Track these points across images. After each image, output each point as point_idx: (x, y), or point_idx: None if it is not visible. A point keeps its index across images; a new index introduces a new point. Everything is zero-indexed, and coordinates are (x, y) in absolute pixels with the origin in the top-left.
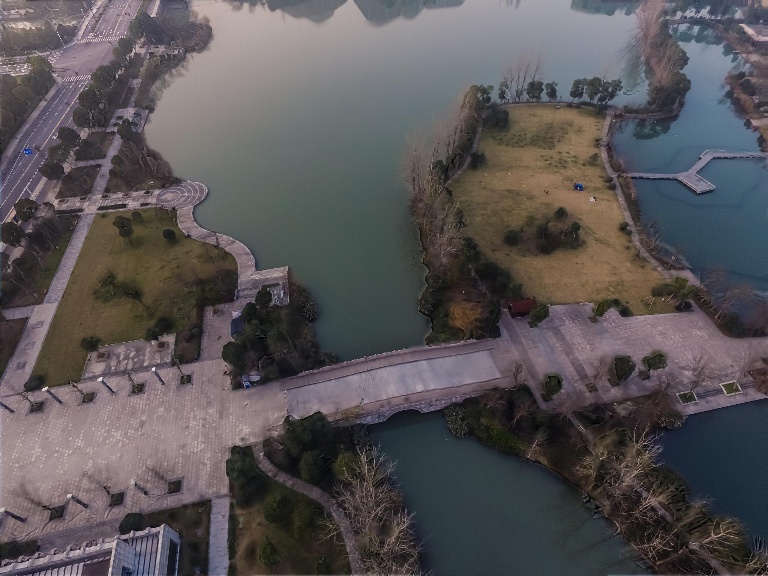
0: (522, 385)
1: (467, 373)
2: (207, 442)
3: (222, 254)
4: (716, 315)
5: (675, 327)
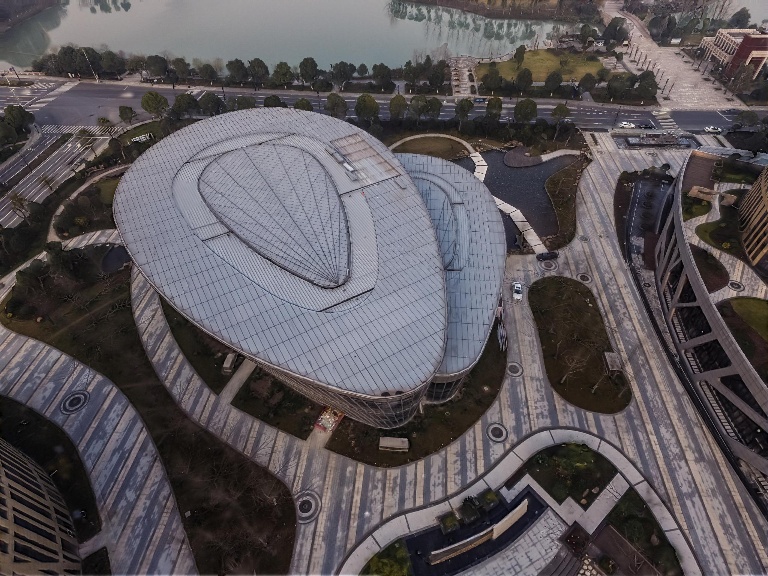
0: (625, 6)
1: None
2: None
3: None
4: None
5: None
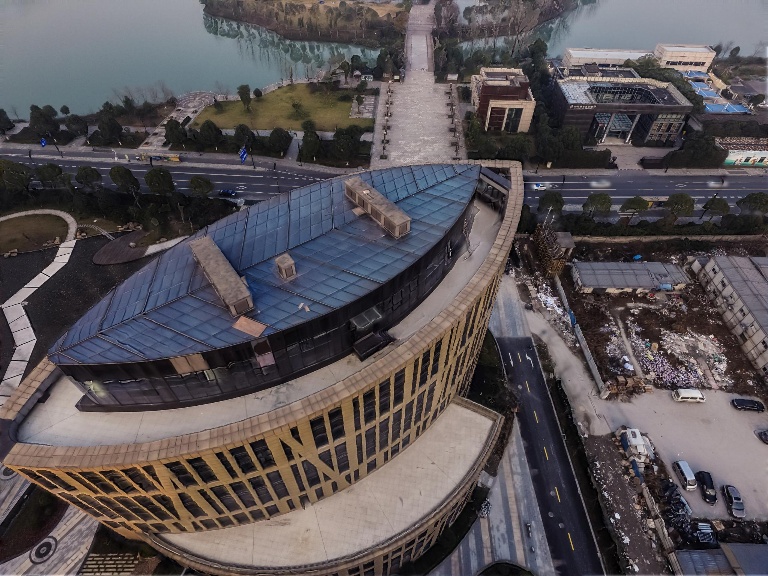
0: (434, 29)
1: (421, 39)
2: (429, 87)
3: (293, 83)
4: (417, 3)
5: (418, 9)
